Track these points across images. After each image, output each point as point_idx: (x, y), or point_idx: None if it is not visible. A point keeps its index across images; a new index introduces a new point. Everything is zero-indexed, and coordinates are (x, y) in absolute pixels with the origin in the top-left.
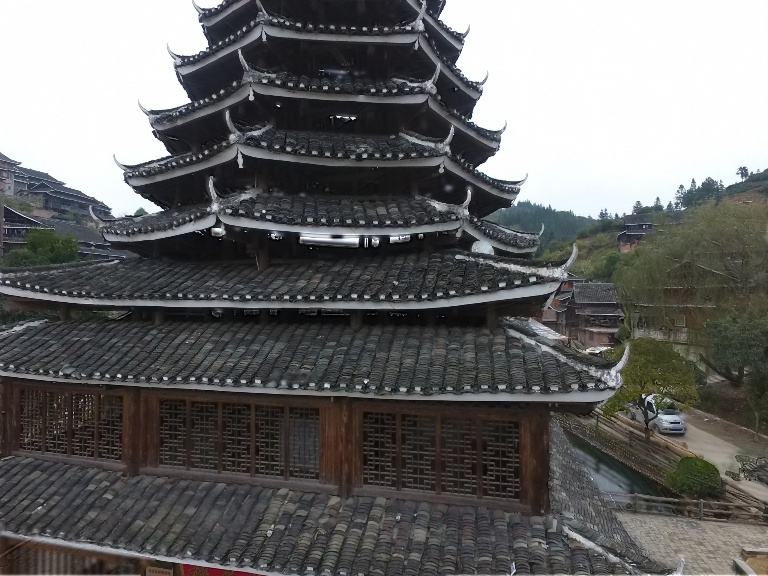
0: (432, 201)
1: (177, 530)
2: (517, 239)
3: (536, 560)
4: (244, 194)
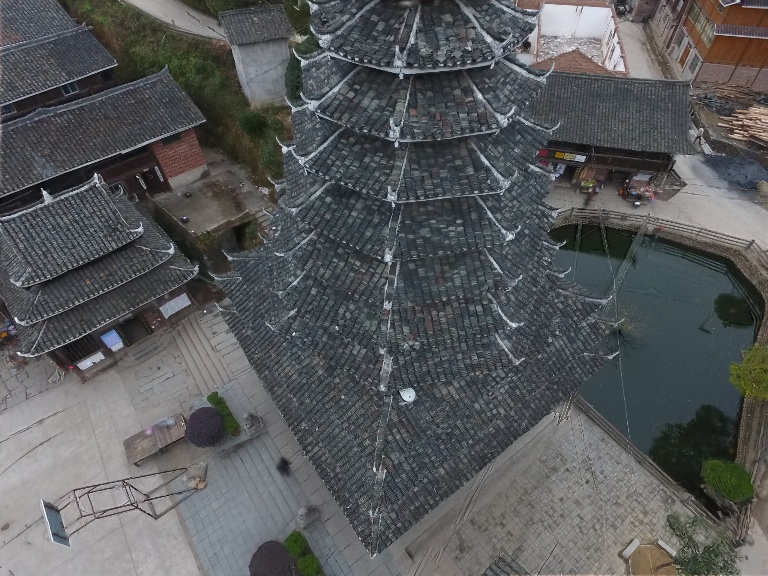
0: (386, 356)
1: (283, 402)
2: (488, 362)
3: (356, 511)
4: (292, 311)
